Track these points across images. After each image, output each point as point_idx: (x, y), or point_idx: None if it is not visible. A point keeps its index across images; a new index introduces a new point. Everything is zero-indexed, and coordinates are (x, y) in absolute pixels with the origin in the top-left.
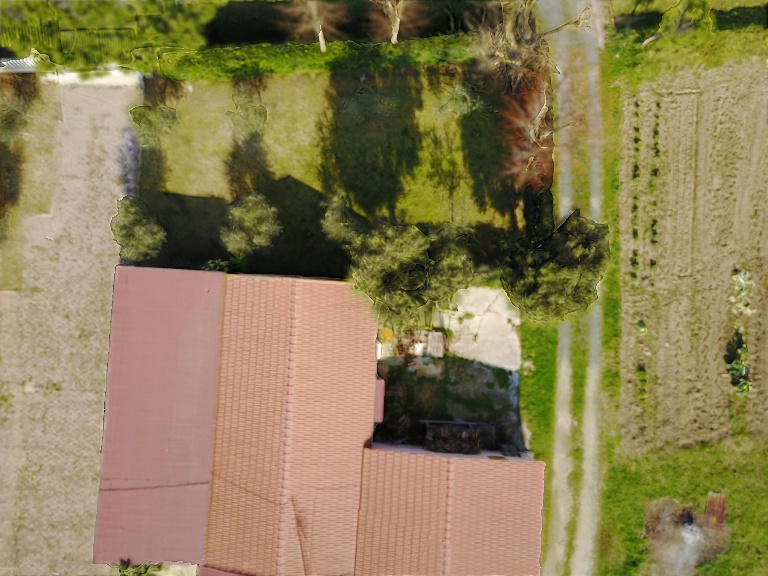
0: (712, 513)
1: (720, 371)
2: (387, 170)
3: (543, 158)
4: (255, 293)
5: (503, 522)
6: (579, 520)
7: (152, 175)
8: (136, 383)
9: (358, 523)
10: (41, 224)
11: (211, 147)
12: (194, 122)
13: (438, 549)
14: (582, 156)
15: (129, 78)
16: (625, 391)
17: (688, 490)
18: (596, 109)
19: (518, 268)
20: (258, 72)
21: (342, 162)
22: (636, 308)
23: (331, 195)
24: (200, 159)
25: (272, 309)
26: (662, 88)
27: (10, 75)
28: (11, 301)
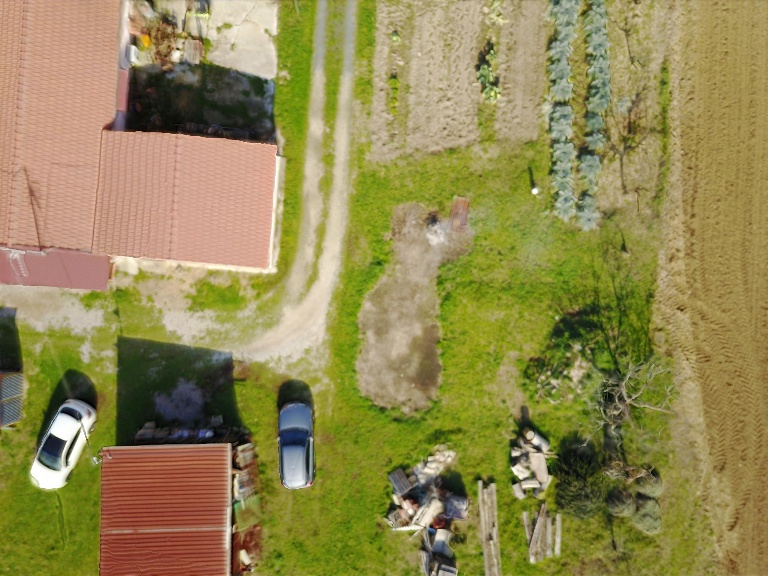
0: (456, 216)
1: (471, 80)
2: None
3: None
4: None
5: (232, 199)
6: (329, 223)
7: None
8: None
9: (96, 202)
10: None
11: None
12: None
13: (166, 220)
14: None
15: None
16: (377, 99)
17: (434, 195)
18: None
19: None
20: None
21: None
22: (390, 19)
23: None
24: None
25: None
26: None
27: None
28: None
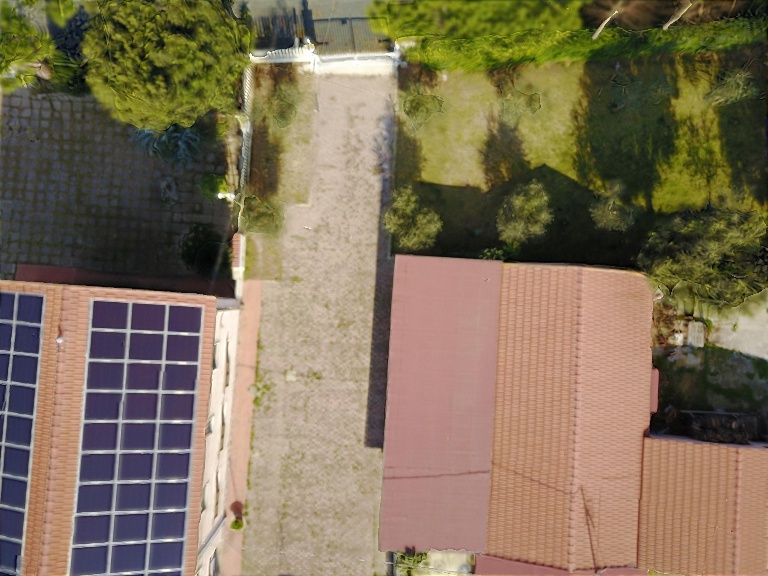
0: None
1: None
2: (642, 158)
3: None
4: (535, 282)
5: None
6: None
7: (407, 164)
8: (416, 372)
9: (639, 513)
10: (299, 214)
11: (466, 136)
12: (448, 111)
13: (727, 539)
14: None
15: (383, 67)
16: None
17: None
18: None
19: None
20: (520, 60)
21: (597, 150)
22: None
23: (587, 184)
24: (455, 148)
25: (555, 298)
26: None
27: (267, 65)
28: (272, 290)
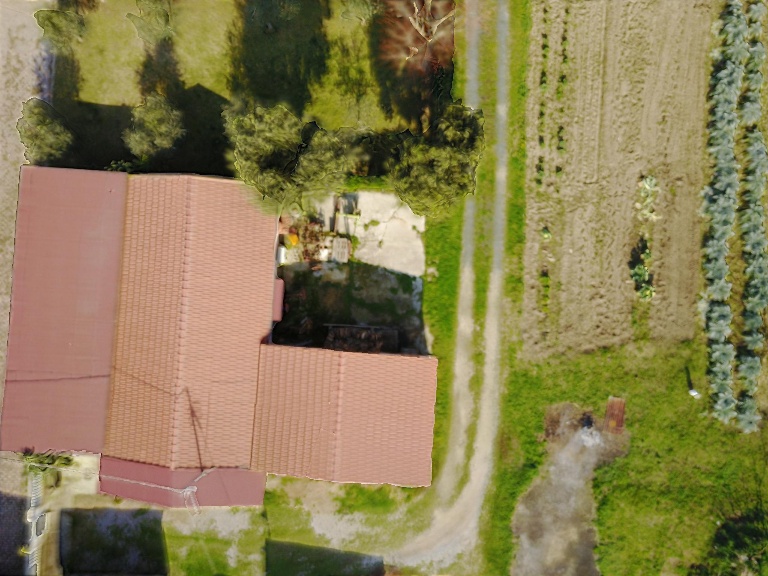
0: (612, 417)
1: (624, 277)
2: (295, 78)
3: (443, 61)
4: (154, 192)
5: (395, 416)
6: (480, 423)
7: (65, 84)
8: (41, 279)
9: (255, 417)
10: None
11: (122, 56)
12: (105, 32)
13: (329, 441)
14: (489, 63)
15: None
16: (528, 297)
17: (589, 395)
18: (504, 16)
19: (398, 157)
20: None
21: (250, 70)
22: (541, 215)
23: None
24: (111, 68)
25: (170, 207)
26: None
27: None
28: None
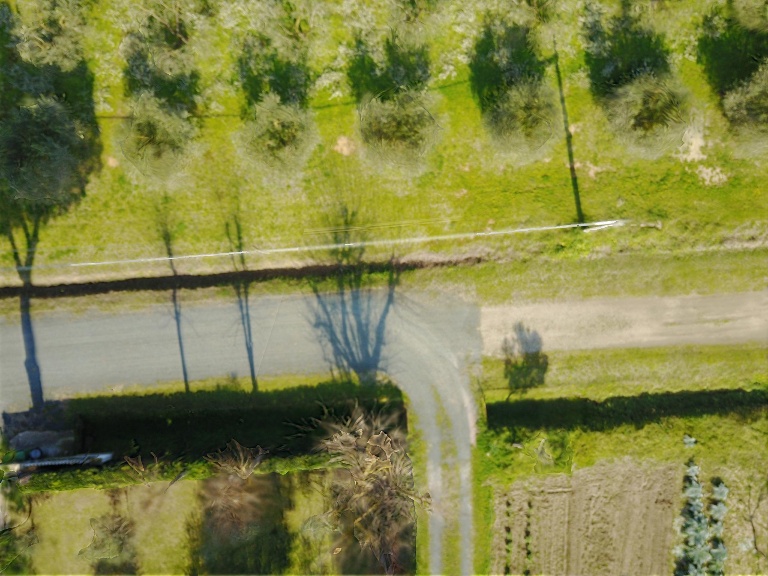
0: None
1: None
2: (255, 571)
3: None
4: None
5: None
6: None
7: None
8: None
9: None
10: None
11: (76, 550)
12: (59, 524)
13: None
14: (452, 558)
15: None
16: None
17: None
18: (466, 508)
19: None
20: None
21: (209, 564)
22: None
23: None
24: (65, 563)
25: None
26: (533, 486)
27: None
28: None
